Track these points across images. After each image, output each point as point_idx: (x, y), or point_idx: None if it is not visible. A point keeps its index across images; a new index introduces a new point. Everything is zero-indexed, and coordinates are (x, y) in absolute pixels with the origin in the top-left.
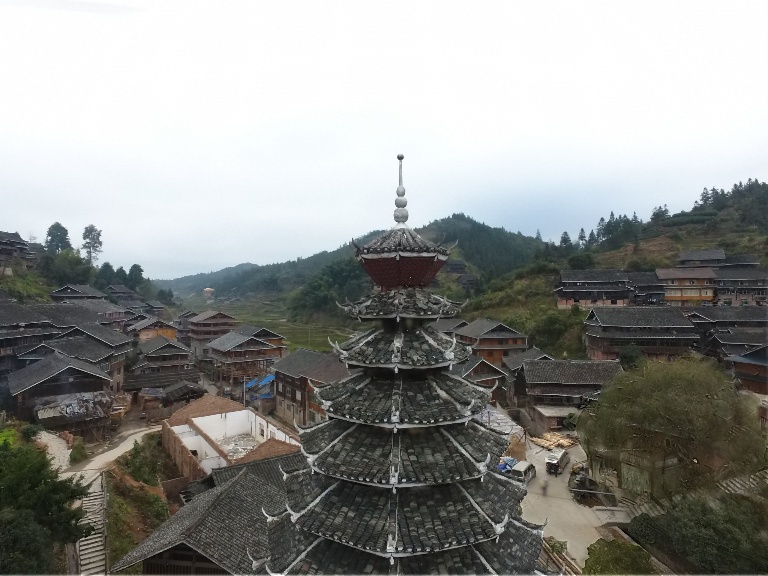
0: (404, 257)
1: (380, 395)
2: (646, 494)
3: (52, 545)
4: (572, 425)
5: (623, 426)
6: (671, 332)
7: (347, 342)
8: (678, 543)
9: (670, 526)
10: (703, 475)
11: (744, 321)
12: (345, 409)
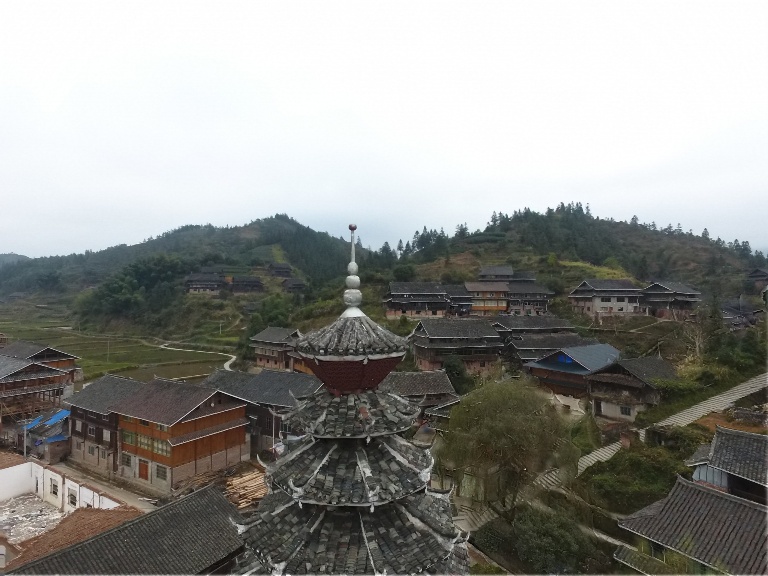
0: (372, 360)
1: (346, 539)
2: (480, 499)
3: None
4: (410, 437)
5: (475, 448)
6: (483, 342)
7: (284, 460)
8: (524, 554)
9: (512, 535)
10: (538, 486)
11: (530, 329)
12: (307, 572)
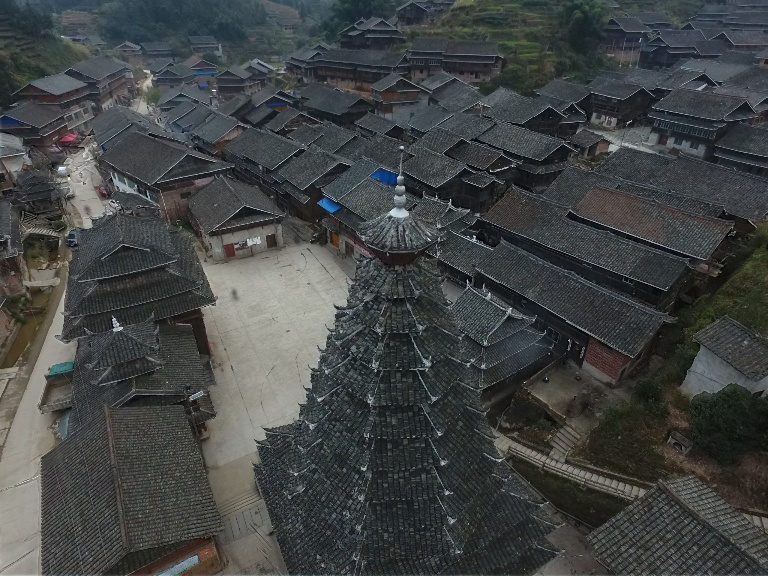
0: None
1: None
2: None
3: (740, 445)
4: None
5: None
6: None
7: None
8: None
9: None
10: None
11: None
12: None
